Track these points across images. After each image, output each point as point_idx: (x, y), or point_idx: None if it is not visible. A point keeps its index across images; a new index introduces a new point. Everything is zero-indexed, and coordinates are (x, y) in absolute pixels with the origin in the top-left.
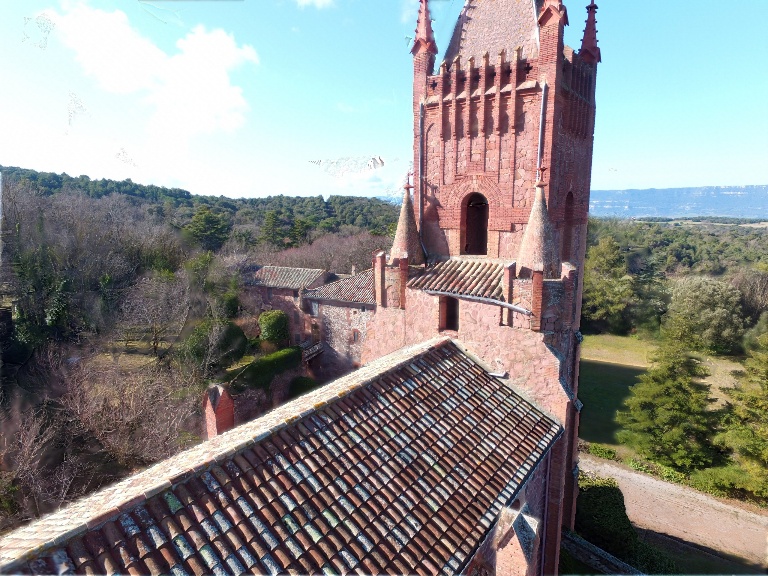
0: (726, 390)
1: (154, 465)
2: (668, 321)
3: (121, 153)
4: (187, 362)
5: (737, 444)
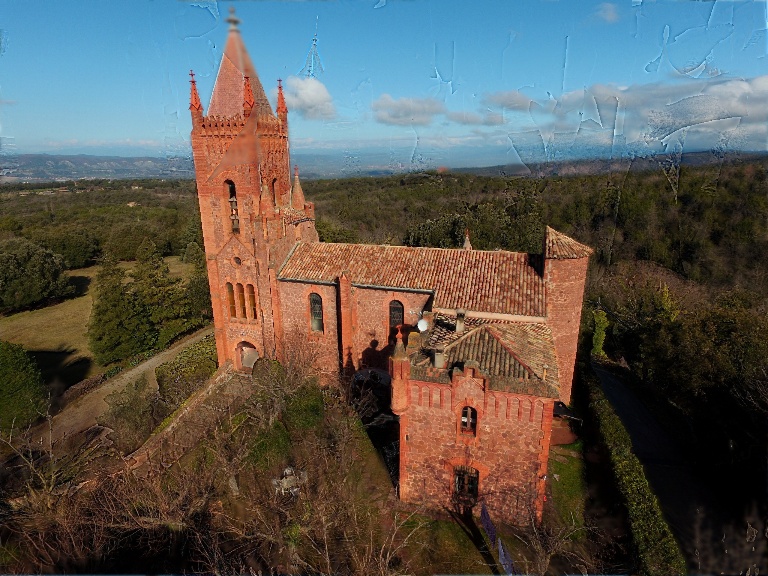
0: (136, 295)
1: None
2: (101, 265)
3: None
4: (3, 492)
5: (167, 314)
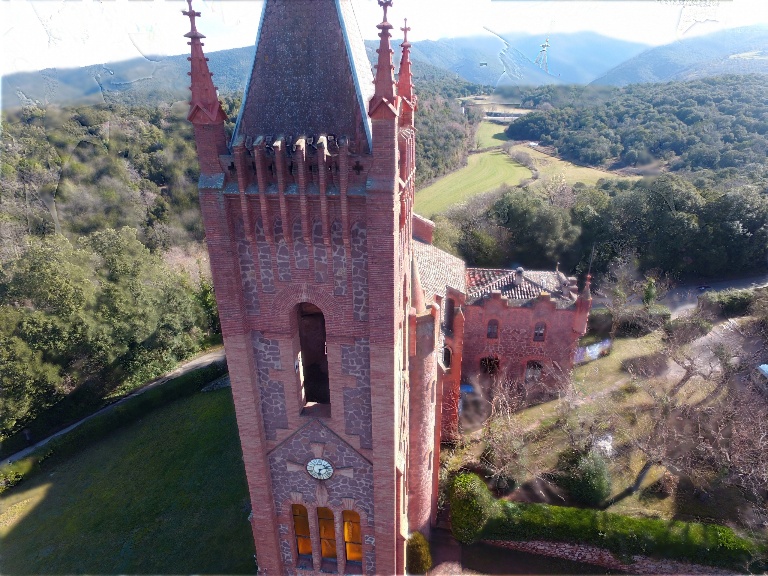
0: None
1: (716, 521)
2: None
3: (657, 182)
4: None
5: None
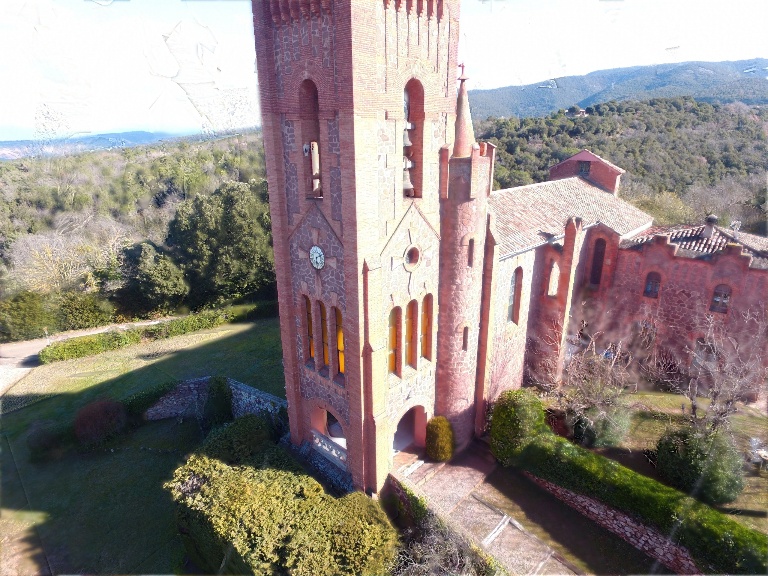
0: None
1: None
2: None
3: None
4: None
5: None
